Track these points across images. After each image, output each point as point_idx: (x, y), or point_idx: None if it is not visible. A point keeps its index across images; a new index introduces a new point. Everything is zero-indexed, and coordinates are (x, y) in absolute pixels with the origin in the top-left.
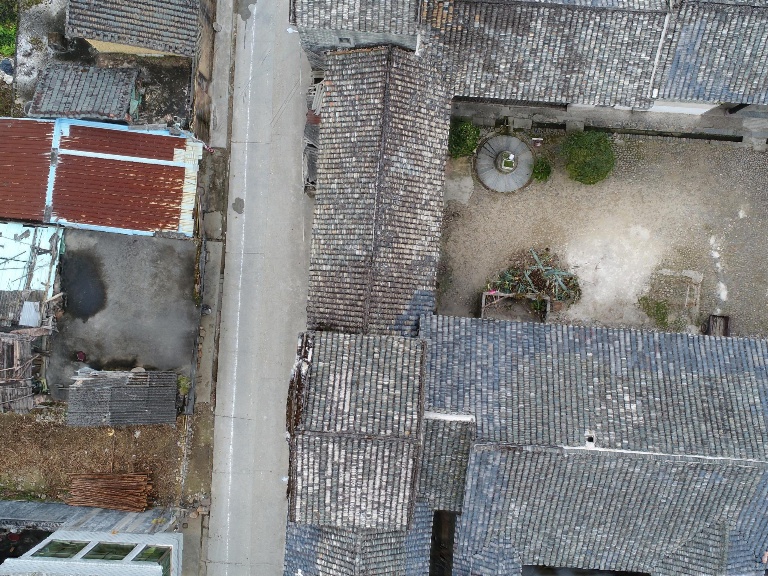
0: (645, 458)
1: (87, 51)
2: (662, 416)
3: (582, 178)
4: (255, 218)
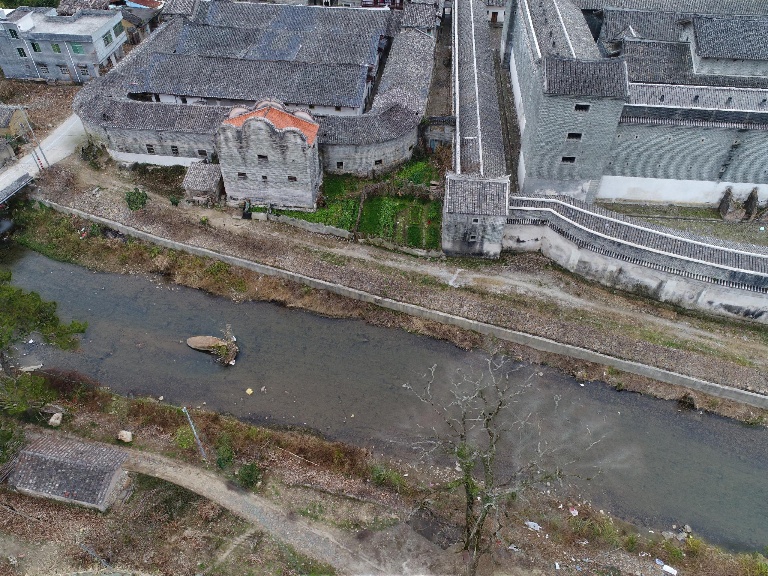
0: (252, 2)
1: None
2: None
3: None
4: None
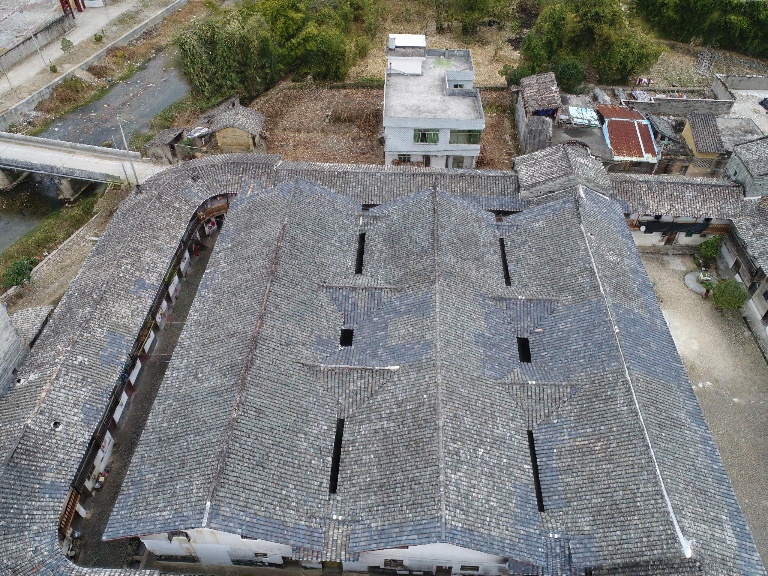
0: None
1: (680, 132)
2: None
3: None
4: None
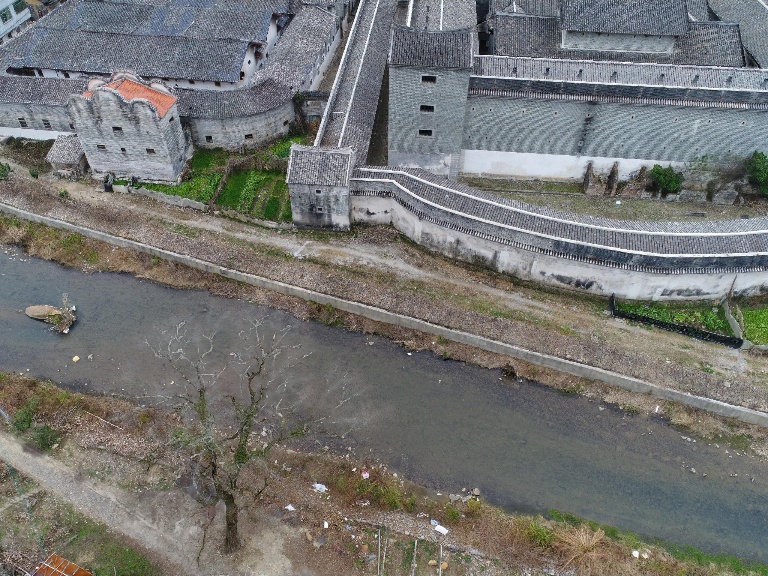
0: None
1: None
2: None
3: None
4: None
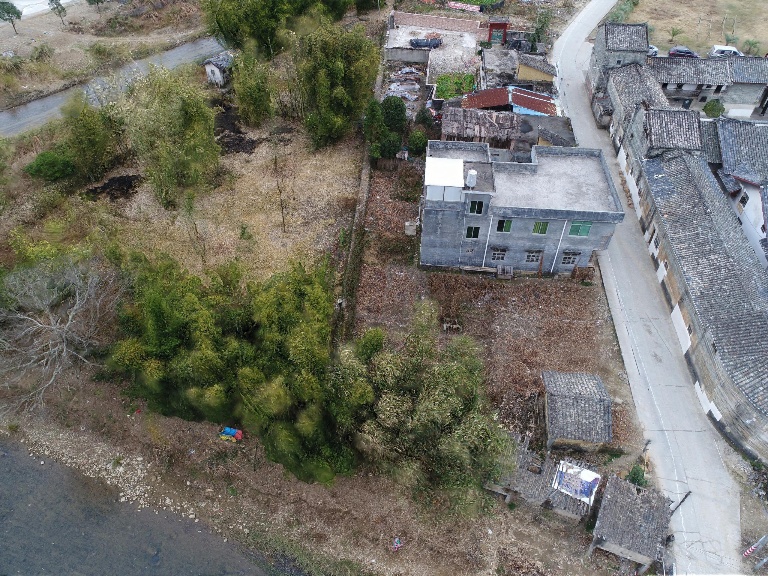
0: None
1: None
2: None
3: (714, 113)
4: (576, 133)
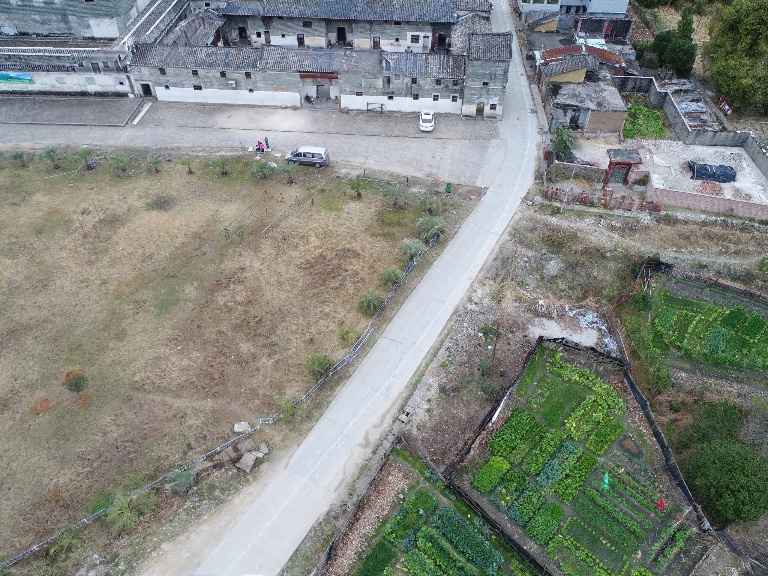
0: None
1: None
2: (387, 0)
3: None
4: None
